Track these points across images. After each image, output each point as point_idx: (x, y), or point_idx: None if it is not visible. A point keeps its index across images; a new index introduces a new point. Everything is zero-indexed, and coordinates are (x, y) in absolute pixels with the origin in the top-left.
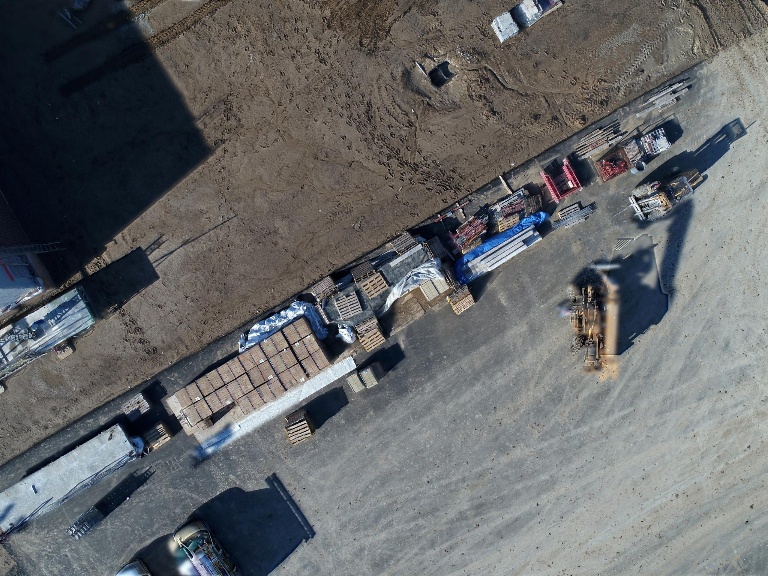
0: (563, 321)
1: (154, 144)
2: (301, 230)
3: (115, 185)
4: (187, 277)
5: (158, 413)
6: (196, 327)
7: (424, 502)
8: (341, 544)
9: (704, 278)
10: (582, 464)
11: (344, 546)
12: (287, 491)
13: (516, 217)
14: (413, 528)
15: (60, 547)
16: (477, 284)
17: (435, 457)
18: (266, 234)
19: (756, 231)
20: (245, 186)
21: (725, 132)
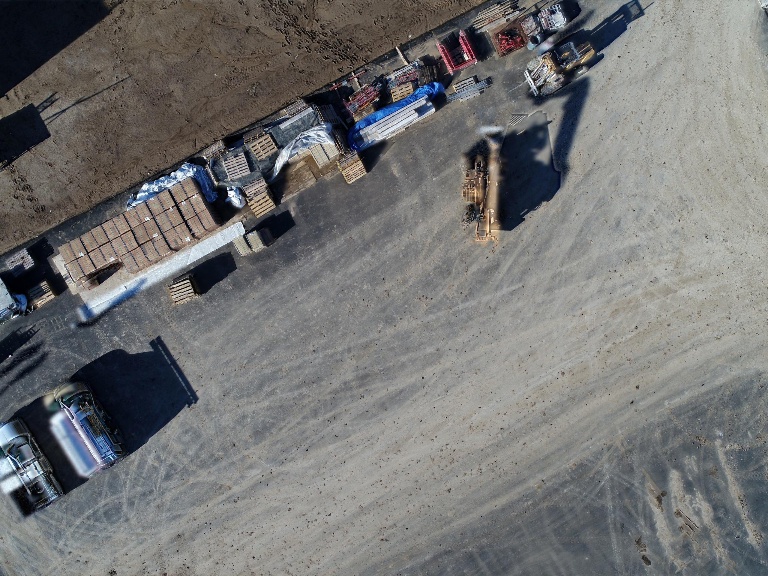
0: (455, 195)
1: (50, 1)
2: (195, 94)
3: (9, 40)
4: (78, 136)
5: (44, 271)
6: (86, 187)
7: (309, 371)
8: (224, 410)
9: (597, 157)
10: (469, 338)
11: (227, 412)
12: (172, 355)
13: (409, 86)
14: (297, 397)
15: None
16: (370, 154)
17: (322, 326)
18: (160, 96)
19: (650, 112)
20: (140, 47)
21: (623, 12)
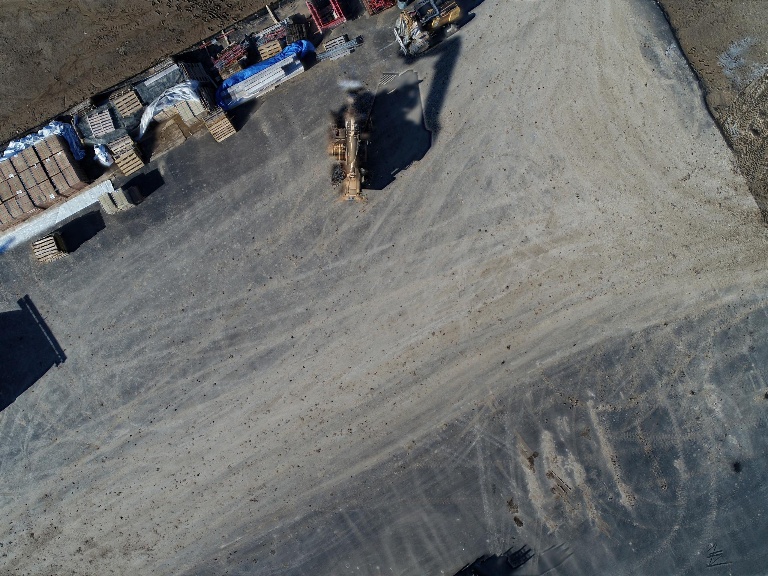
0: (325, 154)
1: None
2: (65, 52)
3: None
4: None
5: None
6: None
7: (178, 330)
8: (92, 370)
9: (468, 116)
10: (339, 298)
11: (95, 372)
12: (40, 314)
13: (277, 44)
14: (166, 356)
15: None
16: (240, 113)
17: (191, 285)
18: (29, 54)
19: (522, 71)
20: (9, 5)
21: None
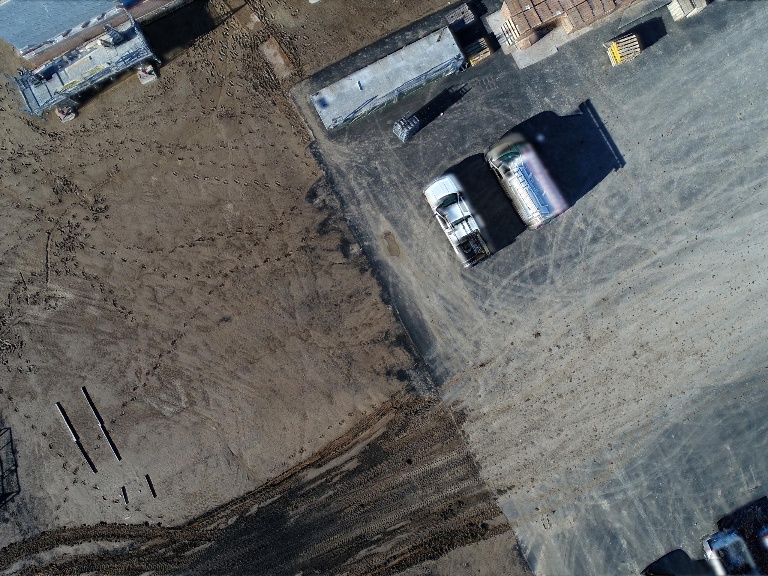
0: None
1: None
2: None
3: None
4: None
5: (477, 30)
6: None
7: (736, 139)
8: (651, 175)
9: None
10: None
11: (654, 178)
12: (600, 119)
13: None
14: (723, 164)
15: (370, 159)
16: None
17: (749, 94)
18: None
19: None
20: None
21: None
